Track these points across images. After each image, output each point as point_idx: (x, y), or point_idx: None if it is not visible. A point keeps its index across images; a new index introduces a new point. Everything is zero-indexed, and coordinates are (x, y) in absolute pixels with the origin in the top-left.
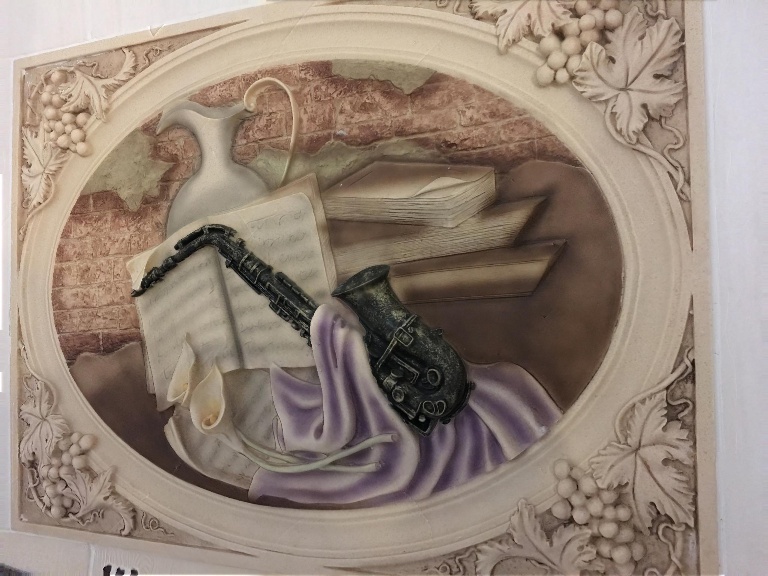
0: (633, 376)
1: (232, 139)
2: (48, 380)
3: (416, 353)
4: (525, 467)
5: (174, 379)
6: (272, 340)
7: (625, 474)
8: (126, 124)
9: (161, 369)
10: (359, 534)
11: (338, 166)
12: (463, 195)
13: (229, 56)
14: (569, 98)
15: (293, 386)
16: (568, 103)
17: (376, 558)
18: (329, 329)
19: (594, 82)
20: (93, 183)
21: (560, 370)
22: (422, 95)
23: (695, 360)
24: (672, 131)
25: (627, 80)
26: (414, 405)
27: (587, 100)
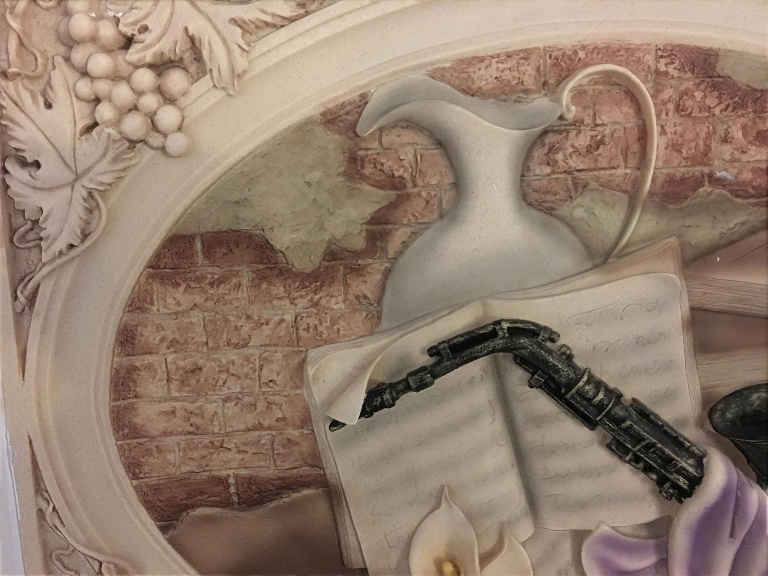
0: None
1: (523, 163)
2: (117, 556)
3: None
4: None
5: (418, 554)
6: (601, 491)
7: None
8: (278, 103)
9: (378, 534)
10: None
11: (715, 228)
12: None
13: (517, 4)
14: None
15: (619, 546)
16: None
17: None
18: (735, 491)
19: None
20: (205, 214)
21: None
22: None
23: None
24: None
25: None
26: None
27: None
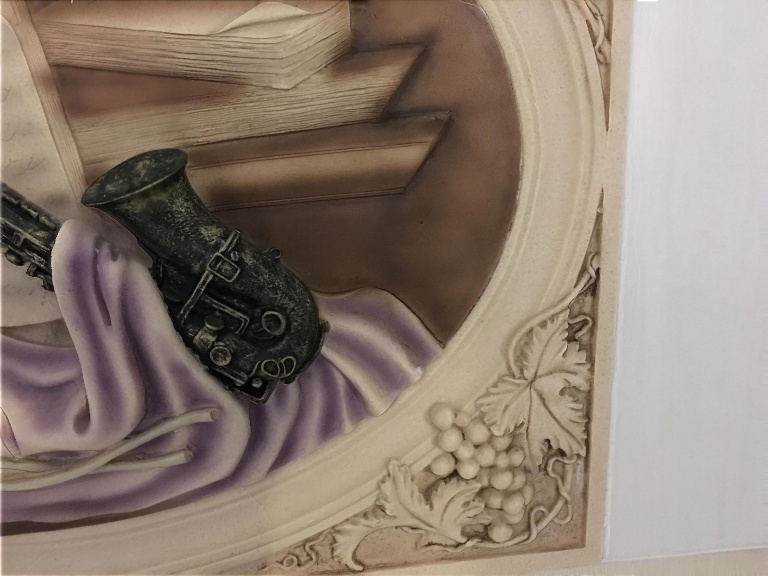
0: (526, 292)
1: None
2: None
3: (243, 290)
4: (393, 419)
5: None
6: None
7: (521, 413)
8: None
9: None
10: (158, 543)
11: None
12: (303, 35)
13: None
14: None
15: (20, 355)
16: None
17: (191, 571)
18: (90, 264)
19: None
20: None
21: (440, 292)
22: None
23: (601, 269)
24: None
25: None
26: (245, 366)
27: None
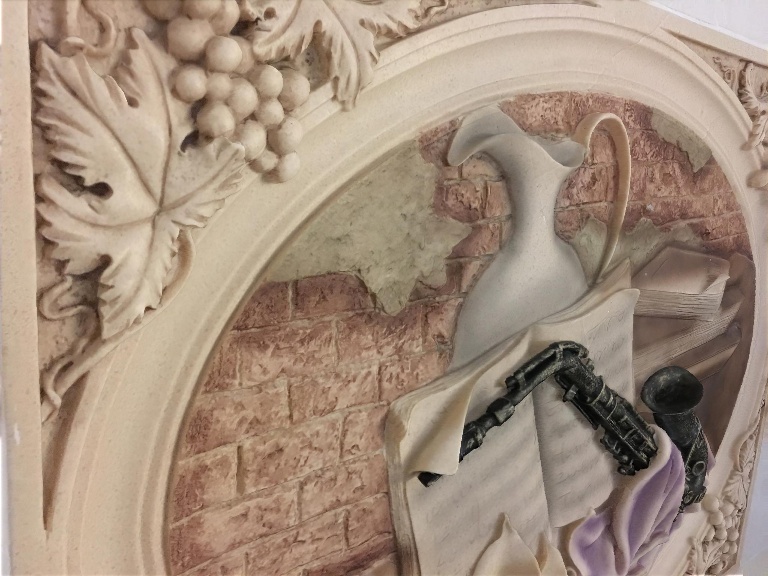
0: (739, 419)
1: None
2: None
3: None
4: None
5: None
6: (591, 481)
7: None
8: (380, 124)
9: None
10: None
11: (645, 250)
12: None
13: (557, 50)
14: (757, 200)
15: (590, 525)
16: None
17: None
18: None
19: None
20: (306, 254)
21: None
22: (701, 176)
23: (766, 401)
24: None
25: None
26: None
27: None
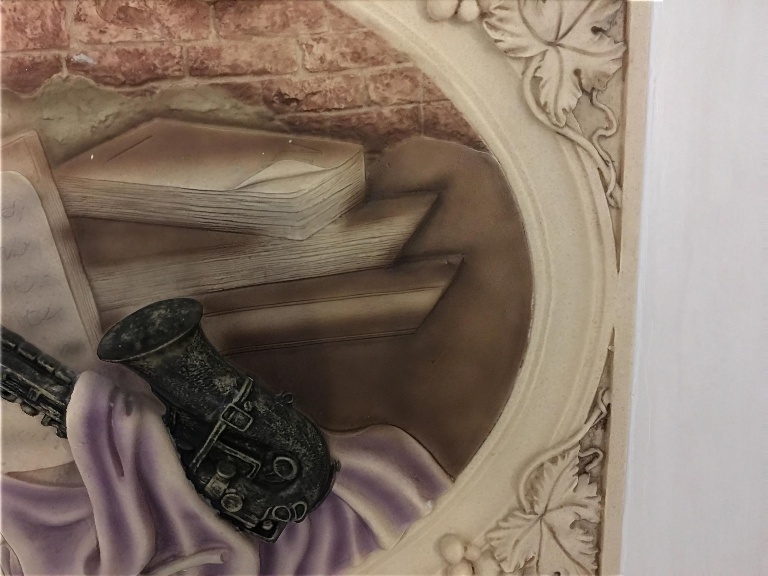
0: (537, 426)
1: None
2: None
3: (256, 437)
4: (403, 551)
5: None
6: None
7: (531, 548)
8: None
9: None
10: None
11: (82, 121)
12: (319, 189)
13: None
14: (471, 44)
15: (32, 496)
16: (469, 52)
17: None
18: (104, 420)
19: (517, 28)
20: None
21: (450, 428)
22: (236, 7)
23: (612, 405)
24: (604, 111)
25: (558, 30)
26: (256, 511)
27: (500, 53)
